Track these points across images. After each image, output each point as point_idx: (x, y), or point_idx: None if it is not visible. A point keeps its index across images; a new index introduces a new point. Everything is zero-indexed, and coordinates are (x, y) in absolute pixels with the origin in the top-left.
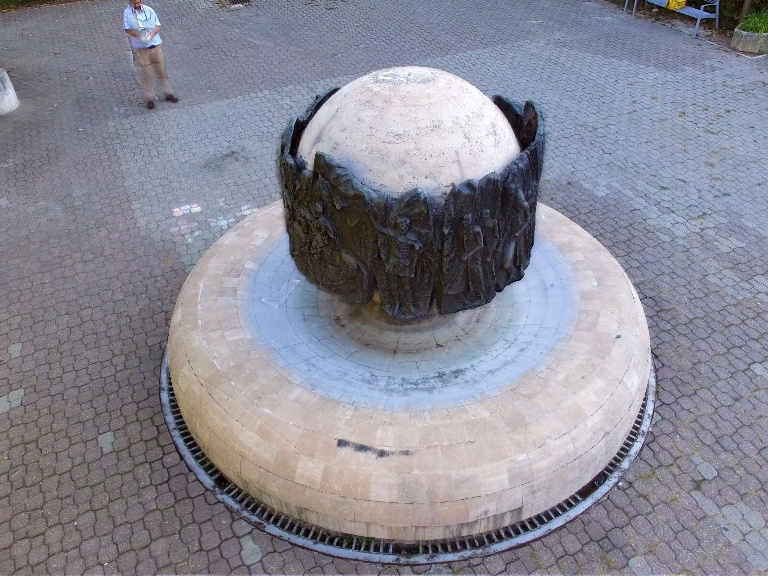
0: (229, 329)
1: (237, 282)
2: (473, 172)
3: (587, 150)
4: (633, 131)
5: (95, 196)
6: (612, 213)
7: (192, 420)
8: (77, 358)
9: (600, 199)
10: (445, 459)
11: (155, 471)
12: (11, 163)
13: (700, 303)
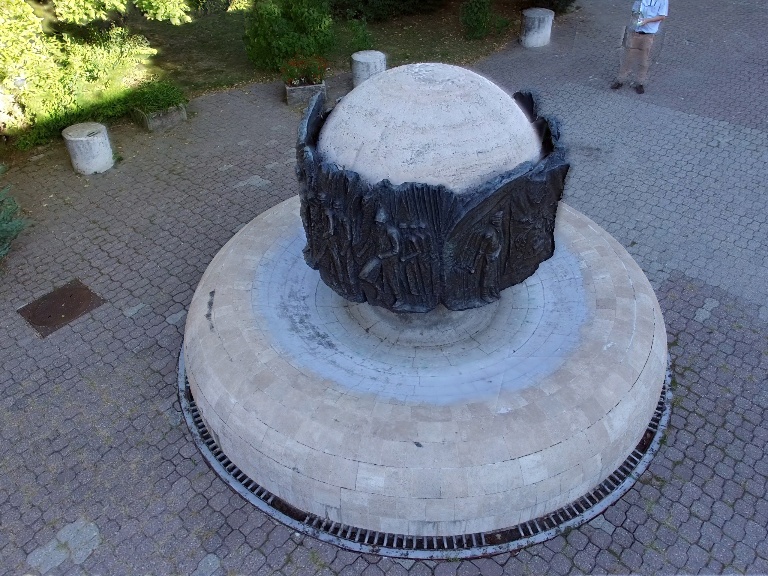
0: None
1: None
2: (364, 168)
3: None
4: None
5: None
6: None
7: None
8: None
9: None
10: (213, 351)
11: None
12: None
13: None
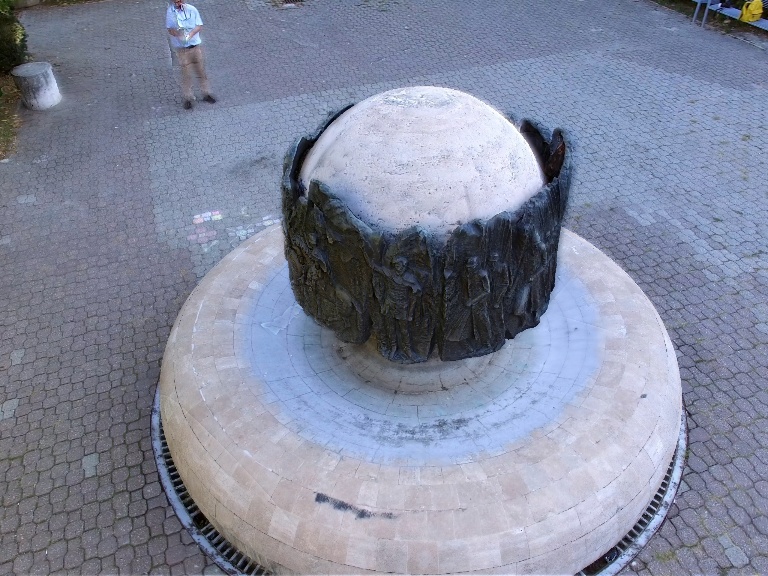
0: (221, 356)
1: (238, 304)
2: (483, 209)
3: (635, 173)
4: (688, 154)
5: (120, 198)
6: (656, 245)
7: (173, 452)
8: (75, 370)
9: (644, 229)
10: (431, 527)
11: (134, 501)
12: (44, 159)
13: (746, 355)
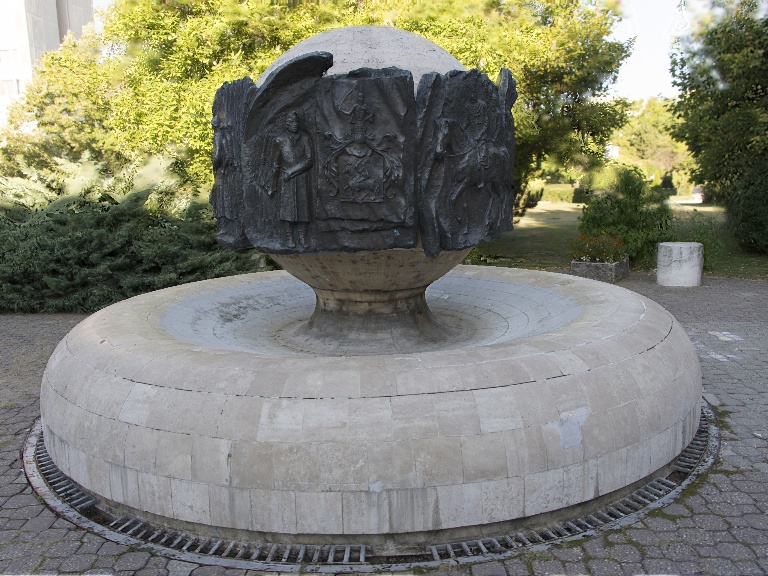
0: None
1: None
2: None
3: None
4: None
5: (766, 314)
6: None
7: None
8: None
9: None
10: None
11: None
12: None
13: None
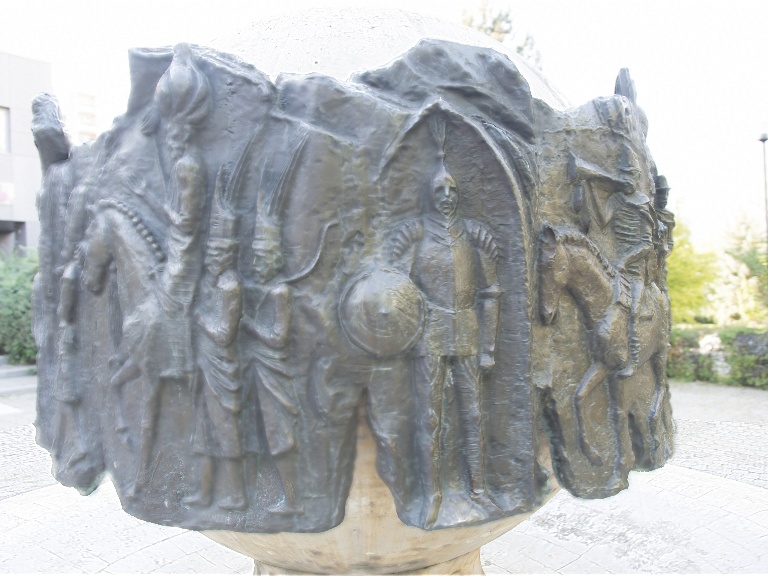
0: None
1: None
2: None
3: None
4: None
5: None
6: None
7: None
8: None
9: None
10: None
11: None
12: None
13: None
